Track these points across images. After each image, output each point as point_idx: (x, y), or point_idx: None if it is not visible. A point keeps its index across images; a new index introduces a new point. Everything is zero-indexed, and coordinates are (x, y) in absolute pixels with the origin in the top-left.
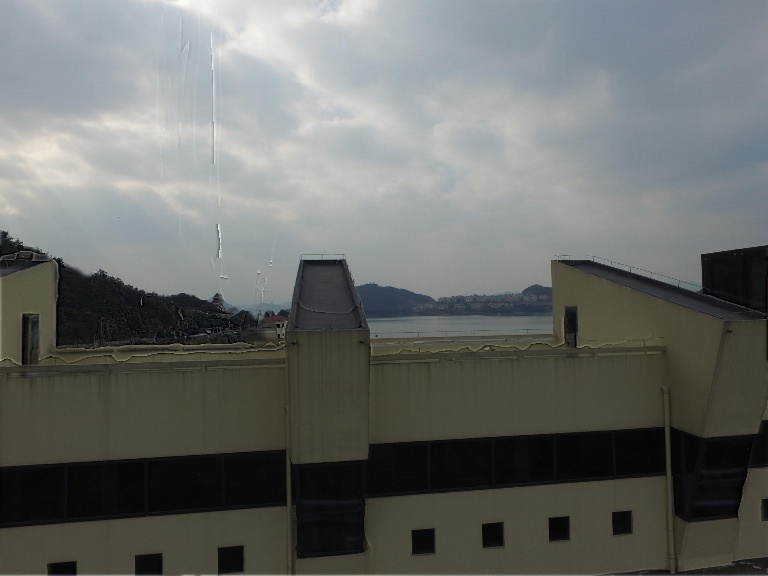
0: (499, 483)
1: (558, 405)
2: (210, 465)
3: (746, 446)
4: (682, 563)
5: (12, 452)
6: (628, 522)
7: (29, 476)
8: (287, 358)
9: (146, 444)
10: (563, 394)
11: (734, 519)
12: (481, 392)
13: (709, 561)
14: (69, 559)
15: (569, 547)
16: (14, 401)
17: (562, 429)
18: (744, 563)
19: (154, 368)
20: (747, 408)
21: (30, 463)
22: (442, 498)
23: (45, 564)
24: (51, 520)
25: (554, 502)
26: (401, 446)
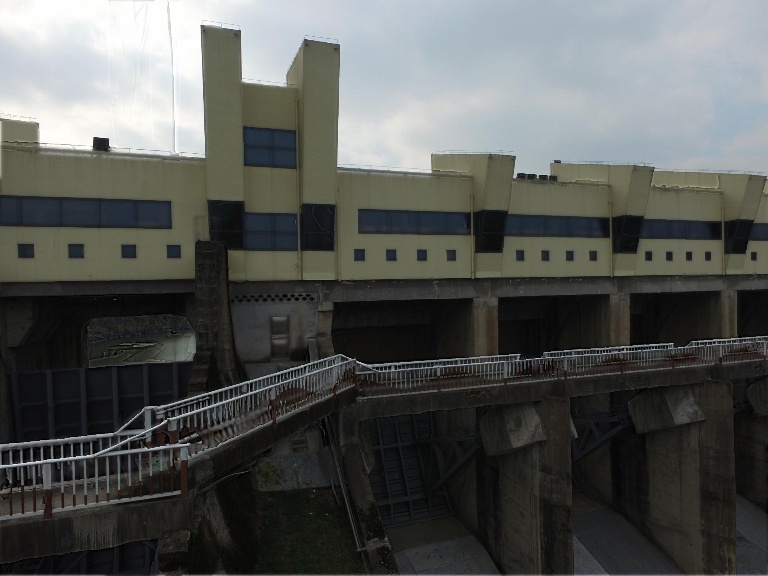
0: None
1: None
2: (702, 225)
3: None
4: None
5: (657, 215)
6: None
7: (661, 223)
8: (747, 183)
9: (687, 216)
10: None
11: None
12: (767, 208)
13: None
14: (671, 251)
15: None
16: (657, 198)
17: None
18: None
19: (689, 191)
20: None
21: (661, 219)
22: (758, 242)
23: (665, 252)
24: (666, 238)
25: None
26: None
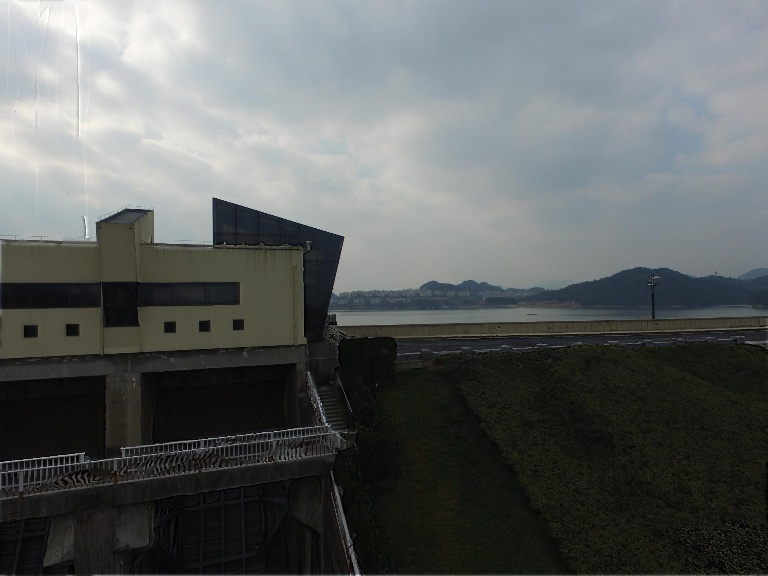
0: None
1: (34, 269)
2: None
3: (131, 288)
4: (106, 350)
5: None
6: (77, 330)
7: None
8: None
9: None
10: (37, 263)
11: (135, 327)
12: None
13: (124, 350)
14: None
15: (37, 341)
16: None
17: (35, 281)
18: (156, 355)
19: None
20: (125, 268)
21: None
22: None
23: None
24: None
25: (28, 318)
26: None
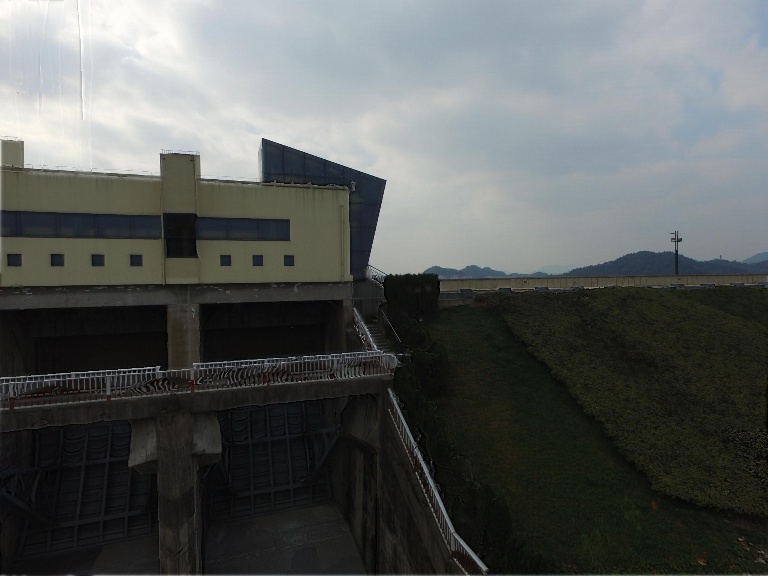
0: (62, 236)
1: (99, 200)
2: None
3: (191, 220)
4: (168, 280)
5: None
6: (140, 260)
7: None
8: None
9: None
10: (101, 195)
11: (194, 258)
12: (50, 190)
13: (184, 280)
14: None
15: (104, 269)
16: None
17: (100, 212)
18: (213, 287)
19: None
20: (186, 200)
21: None
22: (26, 240)
23: None
24: None
25: (95, 247)
26: (0, 212)
